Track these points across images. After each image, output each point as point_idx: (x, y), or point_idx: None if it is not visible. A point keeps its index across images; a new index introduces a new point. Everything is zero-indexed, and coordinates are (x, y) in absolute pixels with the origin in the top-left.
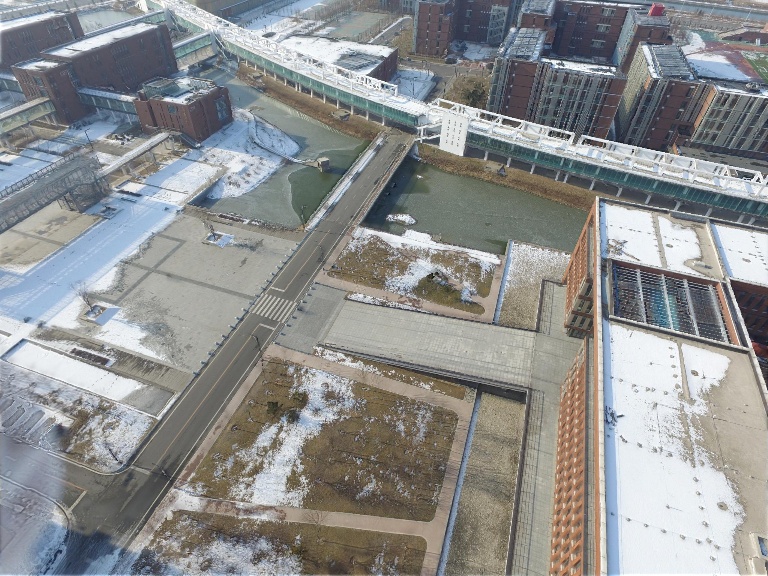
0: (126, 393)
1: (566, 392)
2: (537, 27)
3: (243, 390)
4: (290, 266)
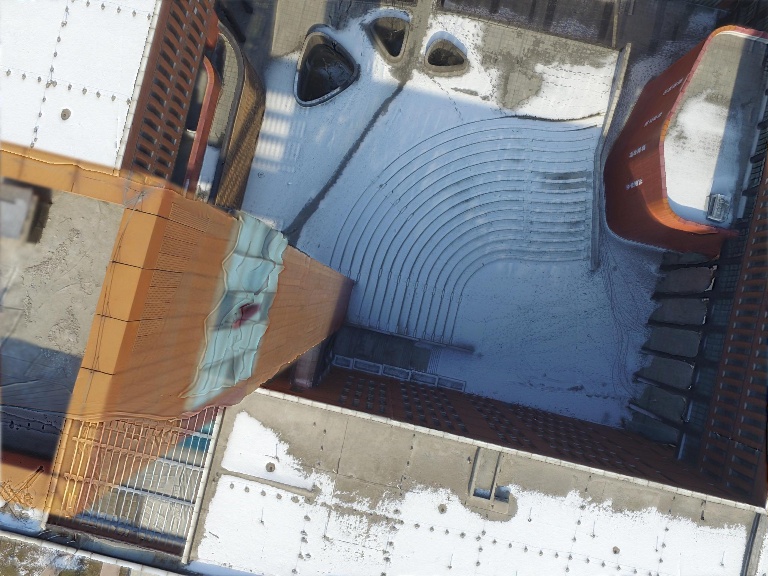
0: None
1: None
2: None
3: None
4: None
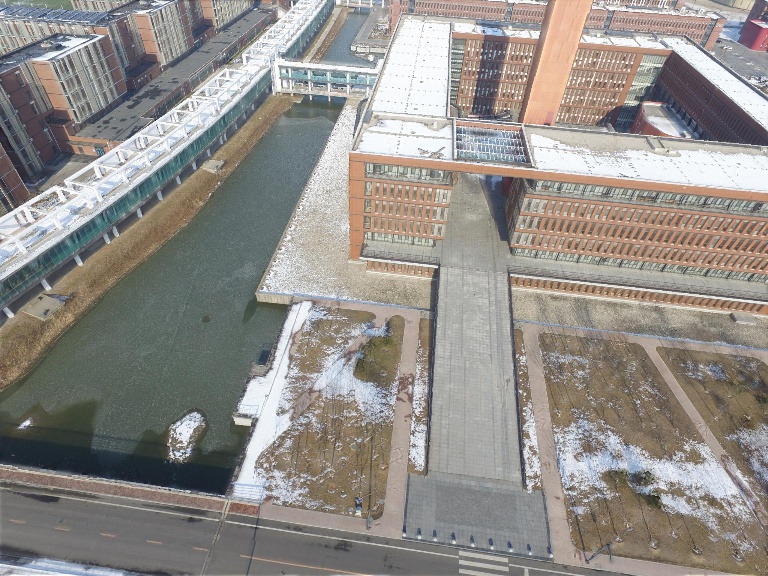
0: None
1: (533, 236)
2: None
3: (645, 569)
4: None
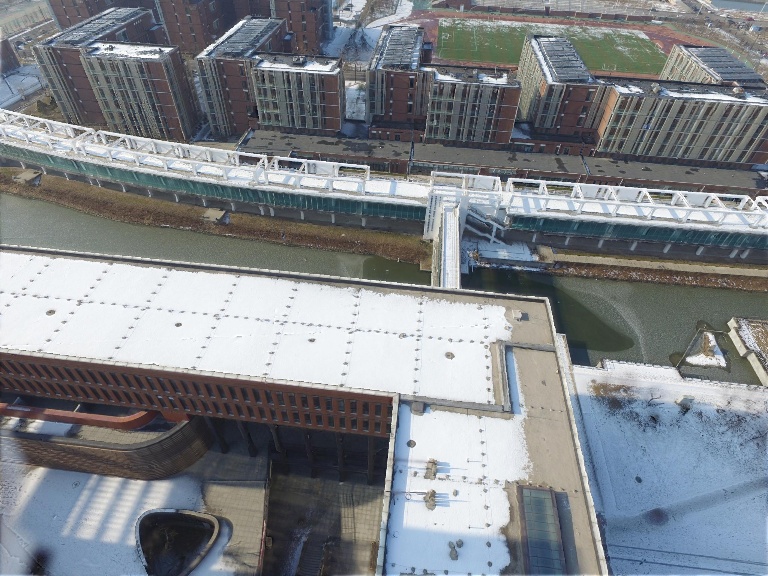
0: None
1: None
2: (177, 6)
3: None
4: None
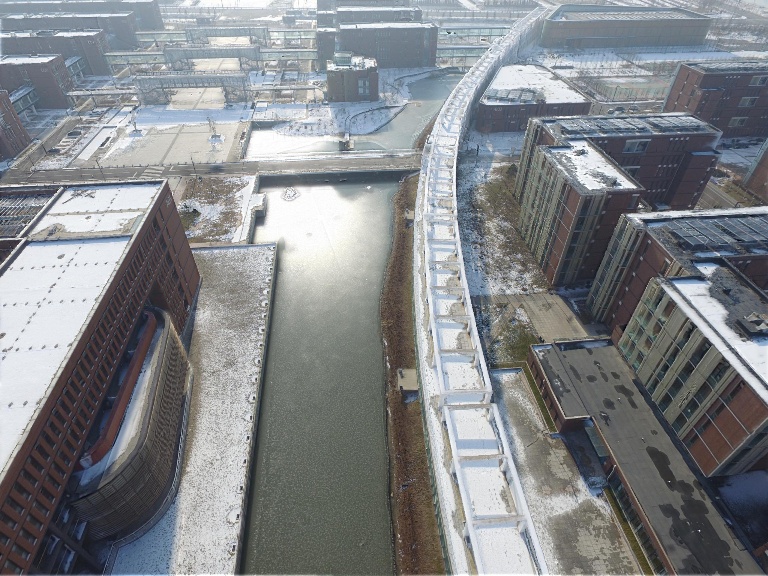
0: (82, 158)
1: None
2: None
3: None
4: (197, 166)
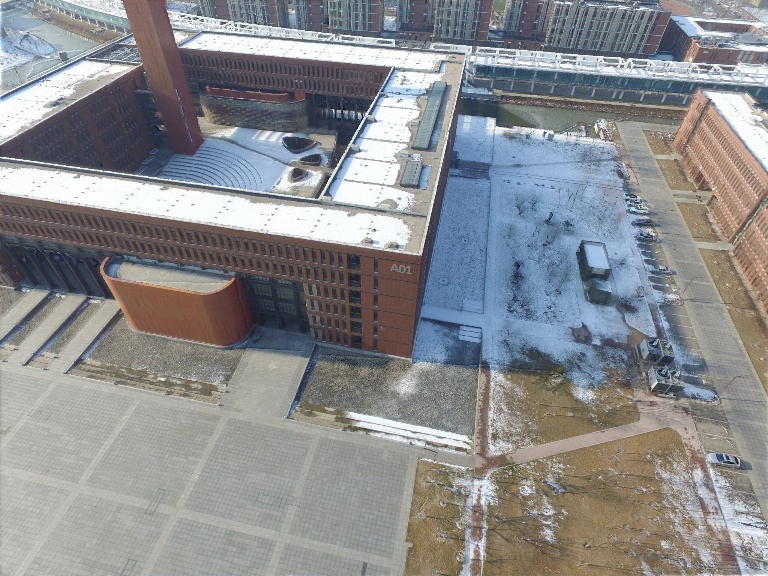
0: None
1: None
2: None
3: None
4: None
